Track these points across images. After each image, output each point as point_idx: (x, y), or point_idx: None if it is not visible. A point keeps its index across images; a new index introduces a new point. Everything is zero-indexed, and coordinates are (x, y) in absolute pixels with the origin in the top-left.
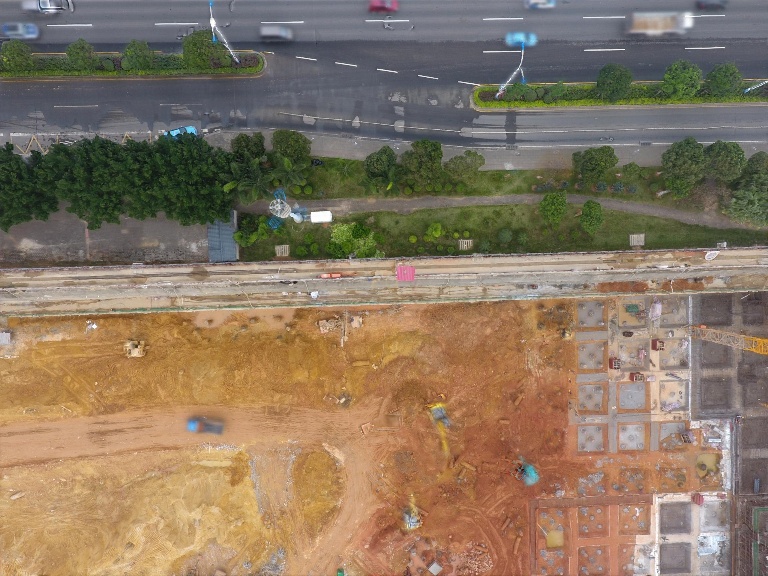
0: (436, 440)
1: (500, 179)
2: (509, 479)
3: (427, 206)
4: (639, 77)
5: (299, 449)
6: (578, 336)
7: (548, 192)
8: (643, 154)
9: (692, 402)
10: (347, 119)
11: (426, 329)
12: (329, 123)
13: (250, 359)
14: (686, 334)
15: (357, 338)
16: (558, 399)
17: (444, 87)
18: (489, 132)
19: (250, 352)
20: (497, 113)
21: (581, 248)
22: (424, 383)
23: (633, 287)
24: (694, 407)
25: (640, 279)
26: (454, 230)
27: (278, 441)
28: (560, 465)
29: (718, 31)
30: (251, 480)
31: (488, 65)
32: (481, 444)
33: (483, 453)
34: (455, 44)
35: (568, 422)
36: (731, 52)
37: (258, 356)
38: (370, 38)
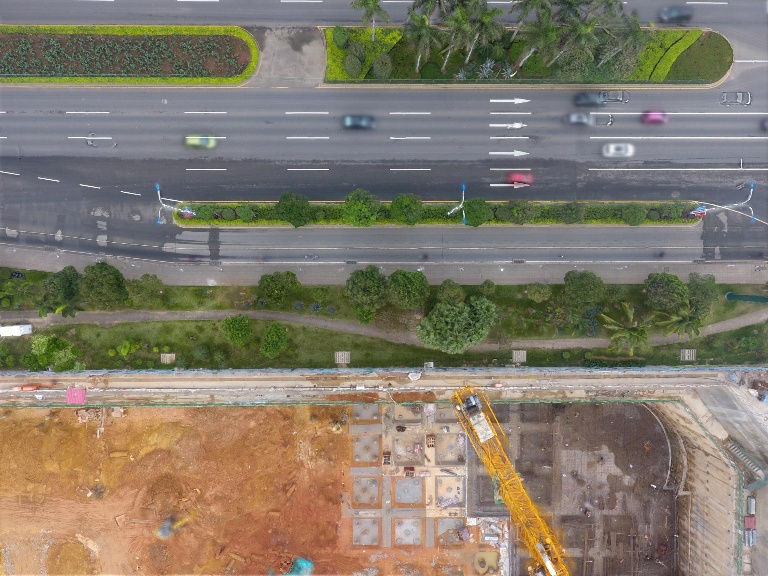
0: (191, 534)
1: (202, 295)
2: (279, 571)
3: (129, 319)
4: (343, 197)
5: (52, 539)
6: (351, 429)
7: (251, 308)
8: (348, 273)
9: (468, 499)
10: (48, 233)
11: (190, 420)
12: (32, 236)
13: (2, 449)
14: (462, 430)
15: (120, 427)
16: (333, 491)
17: (147, 203)
18: (191, 248)
19: (5, 441)
20: (200, 229)
21: (285, 364)
22: (178, 477)
23: (362, 396)
24: (470, 504)
25: (355, 394)
26: (156, 344)
27: (31, 530)
28: (333, 558)
29: (424, 153)
30: (4, 568)
31: (191, 182)
32: (247, 536)
33: (250, 545)
34: (158, 161)
35: (341, 515)
36: (437, 174)
37: (11, 446)
38: (73, 154)
